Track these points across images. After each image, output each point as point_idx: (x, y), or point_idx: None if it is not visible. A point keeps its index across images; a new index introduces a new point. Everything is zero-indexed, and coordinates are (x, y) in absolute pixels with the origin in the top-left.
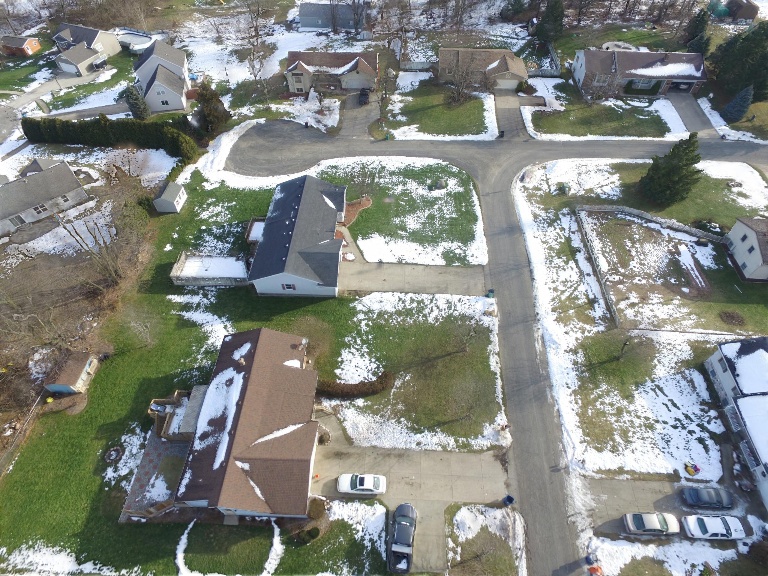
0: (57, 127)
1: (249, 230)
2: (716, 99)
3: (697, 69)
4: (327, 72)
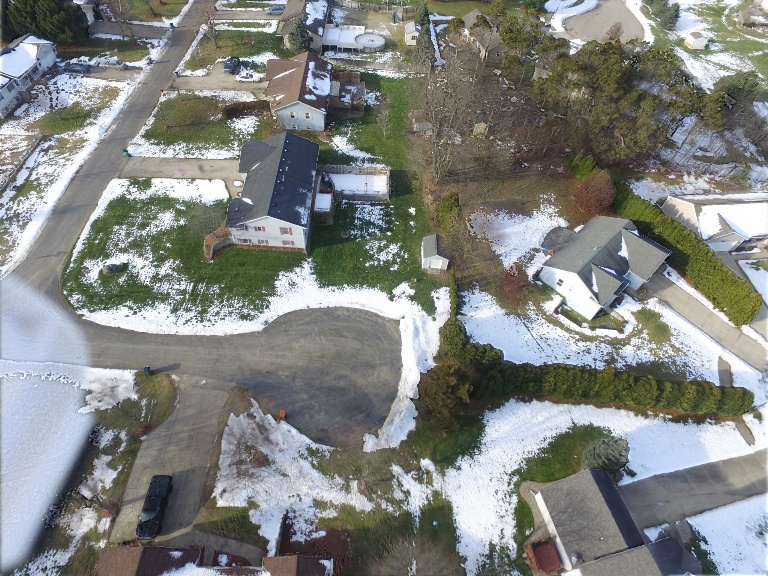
0: (682, 380)
1: (342, 231)
2: None
3: None
4: (224, 572)
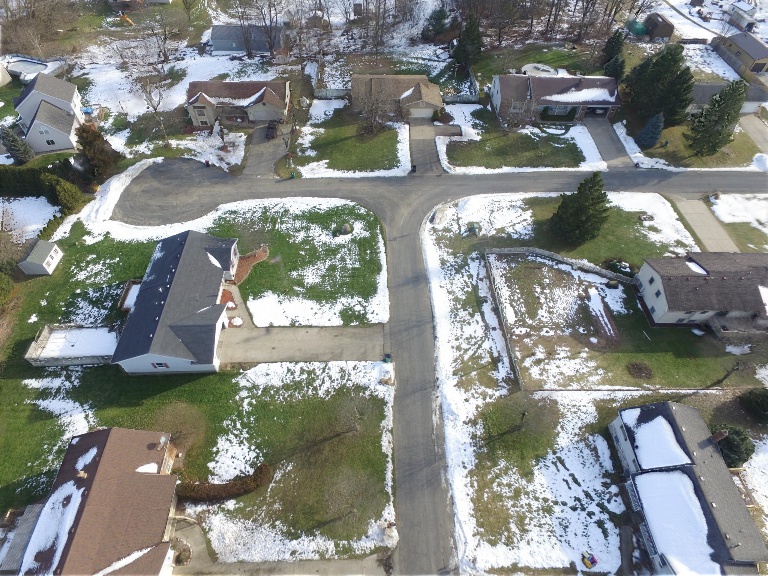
0: None
1: None
2: (631, 124)
3: (611, 94)
4: (232, 104)
